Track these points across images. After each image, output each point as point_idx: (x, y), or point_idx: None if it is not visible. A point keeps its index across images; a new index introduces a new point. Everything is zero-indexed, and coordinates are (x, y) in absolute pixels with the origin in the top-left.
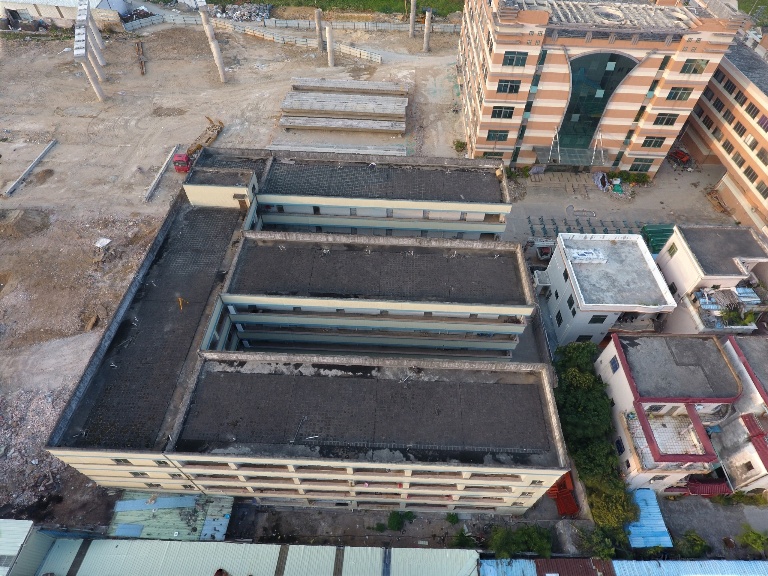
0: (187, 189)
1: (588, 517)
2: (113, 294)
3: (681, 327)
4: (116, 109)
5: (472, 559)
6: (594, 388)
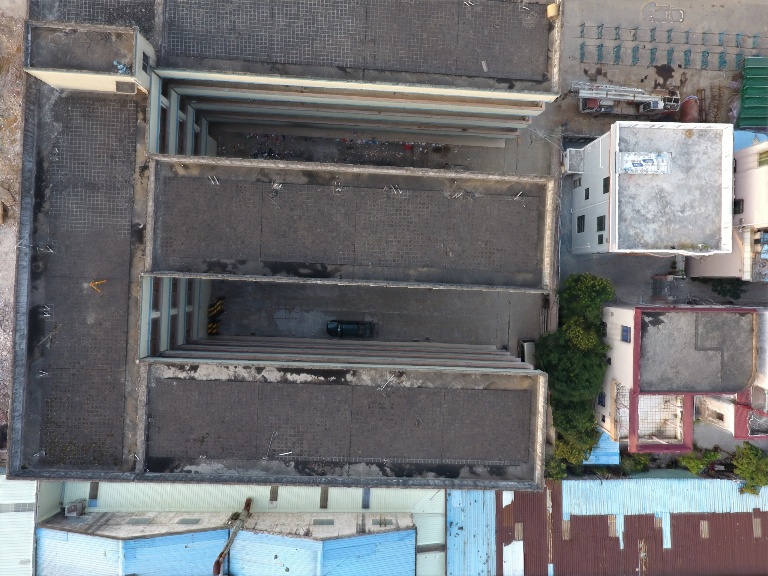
0: (34, 73)
1: (552, 441)
2: (8, 167)
3: (723, 262)
4: None
5: None
6: (594, 348)
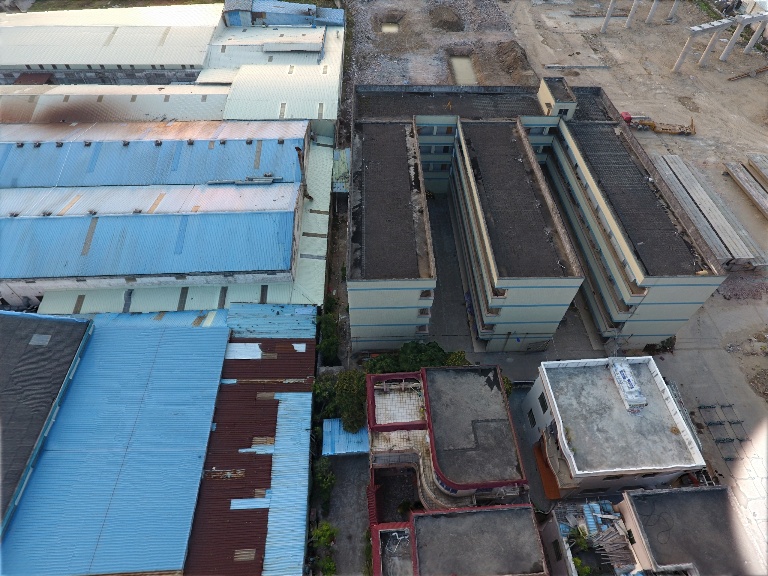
0: (542, 83)
1: None
2: None
3: None
4: (668, 80)
5: (317, 301)
6: None
